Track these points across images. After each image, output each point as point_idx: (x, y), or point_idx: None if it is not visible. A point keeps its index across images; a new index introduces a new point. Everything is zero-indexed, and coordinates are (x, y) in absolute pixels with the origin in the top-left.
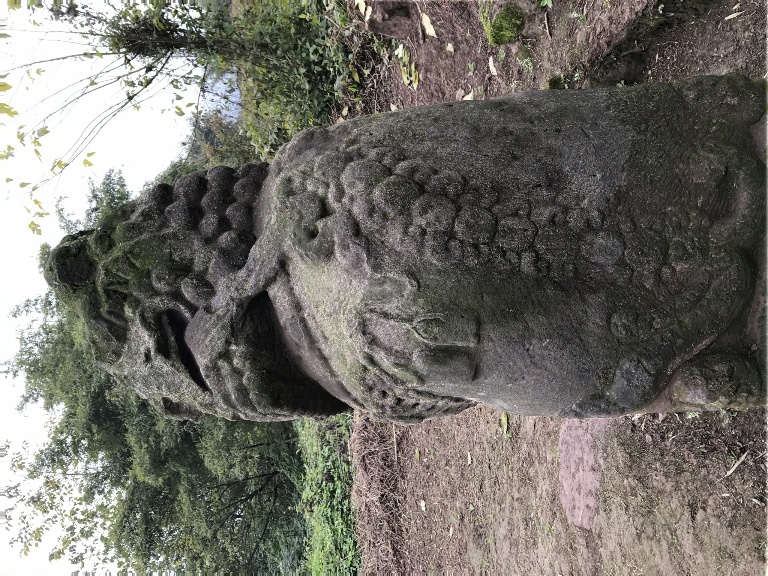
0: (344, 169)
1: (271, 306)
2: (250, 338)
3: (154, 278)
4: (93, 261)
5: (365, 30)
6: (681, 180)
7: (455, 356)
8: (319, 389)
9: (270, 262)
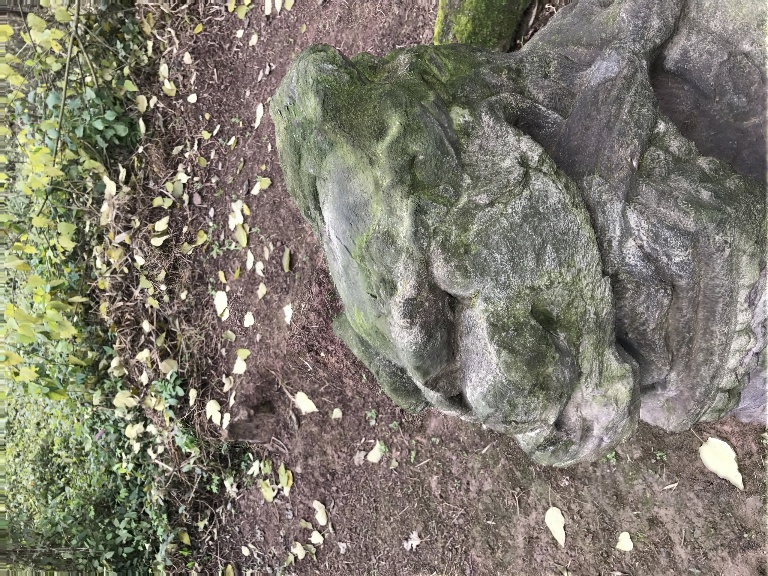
0: None
1: None
2: None
3: (488, 72)
4: None
5: (206, 463)
6: None
7: None
8: None
9: None
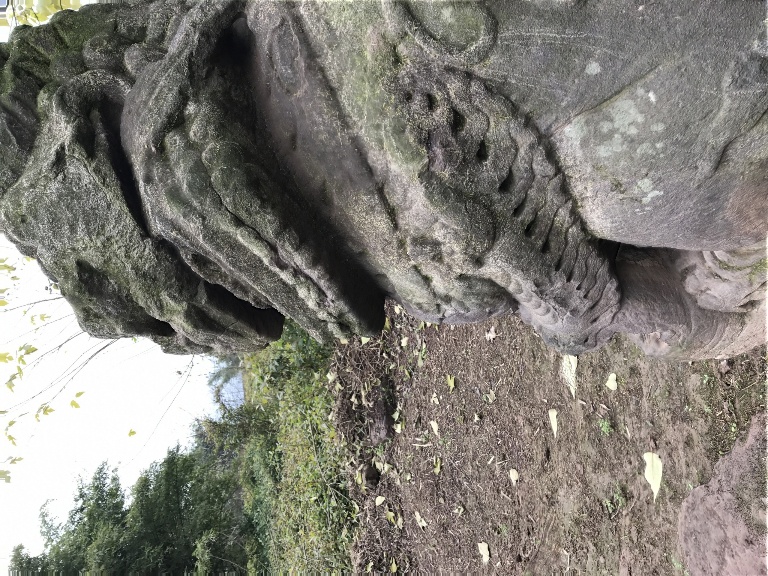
0: None
1: (252, 78)
2: (218, 97)
3: (87, 46)
4: (7, 56)
5: None
6: None
7: None
8: (323, 236)
9: None
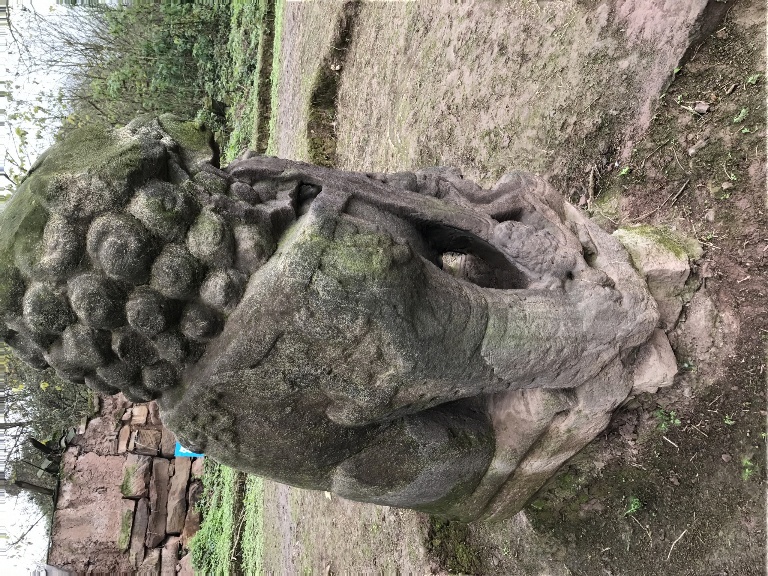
0: None
1: None
2: None
3: None
4: None
5: None
6: None
7: None
8: None
9: None
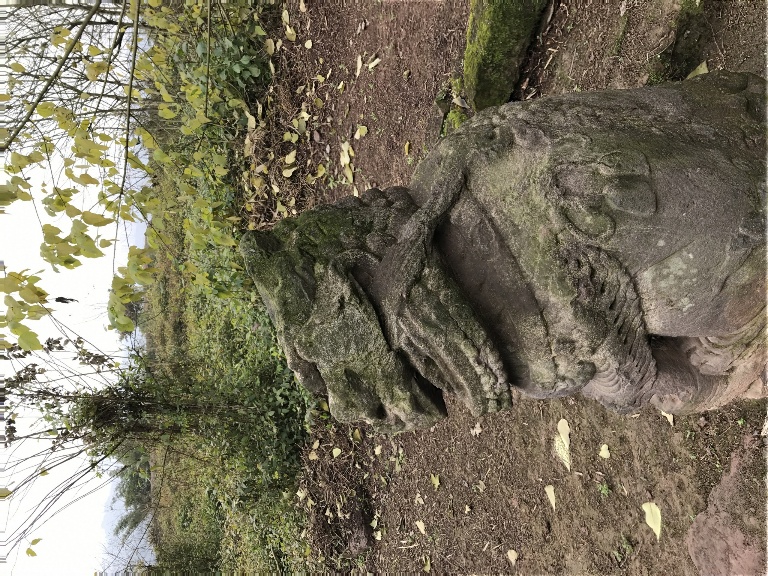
0: (499, 107)
1: (446, 250)
2: (439, 263)
3: (343, 235)
4: (280, 241)
5: None
6: (723, 106)
7: (637, 182)
8: None
9: (456, 178)
